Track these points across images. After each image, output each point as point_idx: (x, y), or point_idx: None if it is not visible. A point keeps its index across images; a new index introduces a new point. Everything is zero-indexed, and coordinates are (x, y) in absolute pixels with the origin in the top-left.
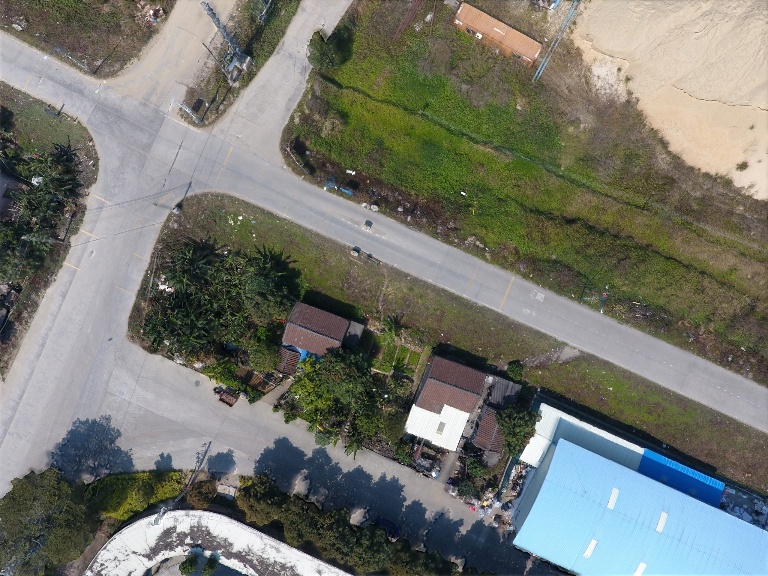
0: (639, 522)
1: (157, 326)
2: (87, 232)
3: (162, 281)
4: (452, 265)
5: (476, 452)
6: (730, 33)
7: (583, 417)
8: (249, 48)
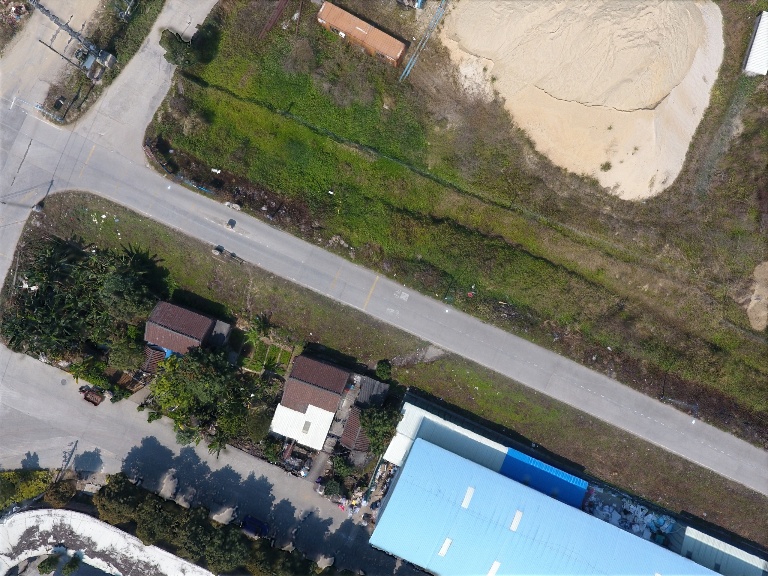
0: (493, 521)
1: (14, 325)
2: None
3: (26, 280)
4: (316, 264)
5: (343, 451)
6: (582, 33)
7: (452, 416)
8: (111, 46)
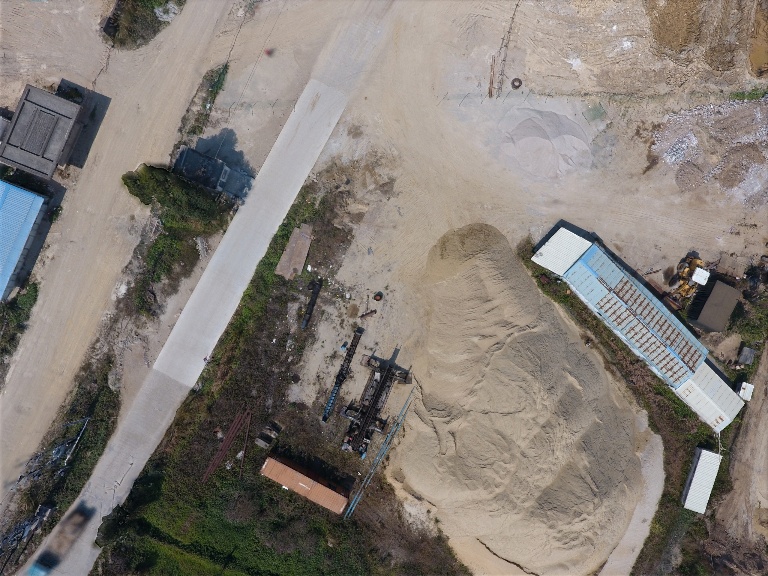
0: None
1: None
2: None
3: None
4: None
5: None
6: (520, 522)
7: None
8: (50, 499)
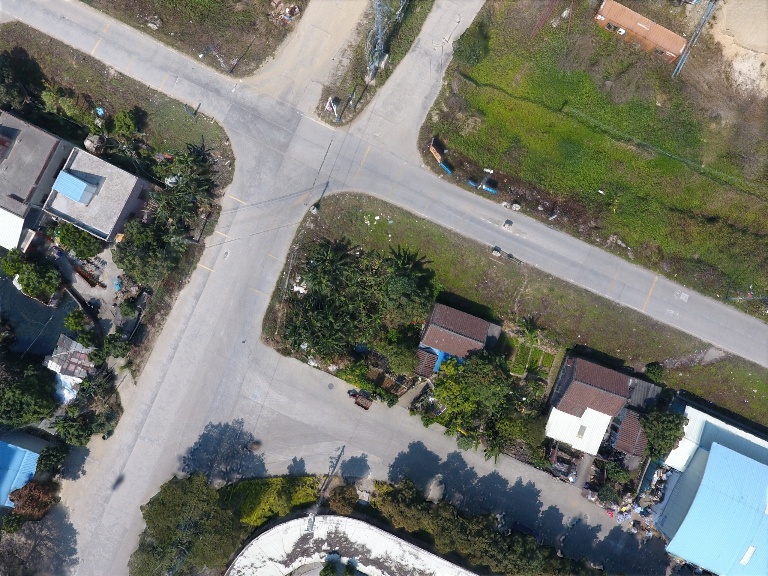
0: None
1: (299, 328)
2: (222, 233)
3: (297, 282)
4: (594, 265)
5: (616, 456)
6: None
7: (723, 420)
8: (387, 46)
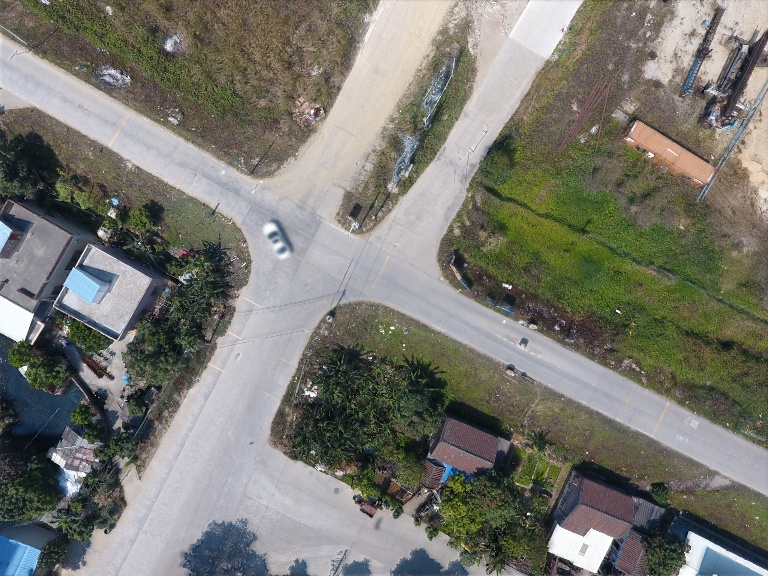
0: None
1: (308, 439)
2: (234, 334)
3: (308, 387)
4: (607, 387)
5: (616, 574)
6: None
7: (723, 542)
8: (412, 155)
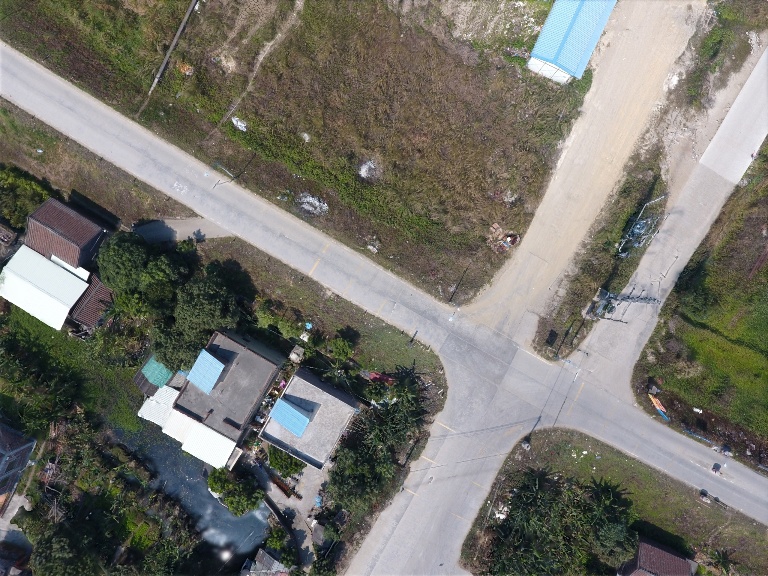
0: None
1: (508, 568)
2: (428, 458)
3: (499, 510)
4: None
5: None
6: None
7: None
8: (608, 283)
